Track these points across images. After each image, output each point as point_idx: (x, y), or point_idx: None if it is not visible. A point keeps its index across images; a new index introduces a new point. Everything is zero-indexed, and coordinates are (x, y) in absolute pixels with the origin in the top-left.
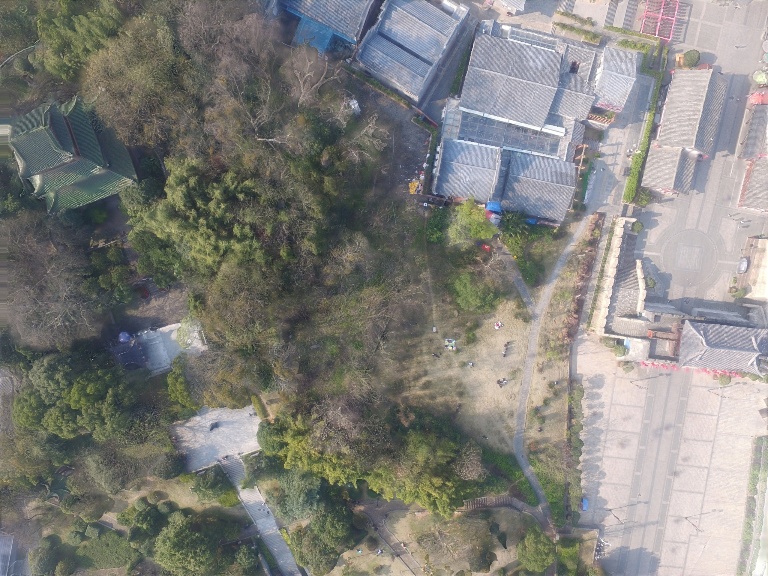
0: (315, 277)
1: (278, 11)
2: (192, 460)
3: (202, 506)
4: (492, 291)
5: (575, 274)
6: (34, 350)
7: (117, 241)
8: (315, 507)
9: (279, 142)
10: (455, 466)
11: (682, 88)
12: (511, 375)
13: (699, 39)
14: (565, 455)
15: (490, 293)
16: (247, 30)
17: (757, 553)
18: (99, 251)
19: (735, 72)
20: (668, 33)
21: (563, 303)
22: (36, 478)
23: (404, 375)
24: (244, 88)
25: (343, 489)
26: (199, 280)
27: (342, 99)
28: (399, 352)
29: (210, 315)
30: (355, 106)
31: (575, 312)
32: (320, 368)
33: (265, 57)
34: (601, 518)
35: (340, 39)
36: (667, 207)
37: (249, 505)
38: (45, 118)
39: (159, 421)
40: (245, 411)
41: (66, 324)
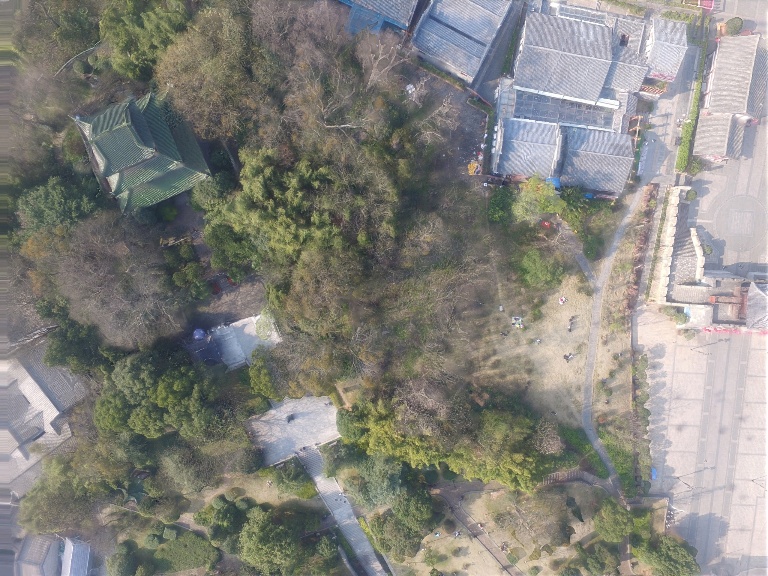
0: (391, 261)
1: None
2: (269, 454)
3: (279, 500)
4: (561, 265)
5: (633, 245)
6: (116, 351)
7: (187, 238)
8: (398, 491)
9: (354, 127)
10: (534, 441)
11: (729, 55)
12: (577, 349)
13: (738, 7)
14: (632, 426)
15: (559, 267)
16: (322, 16)
17: None
18: (169, 249)
19: None
20: (710, 2)
21: (623, 275)
22: (116, 482)
23: (473, 356)
24: (320, 74)
25: (419, 473)
26: (277, 270)
27: (400, 84)
28: None
29: (298, 303)
30: None
31: (634, 283)
32: (392, 354)
33: (338, 43)
34: (669, 486)
35: (390, 26)
36: (717, 174)
37: (326, 496)
38: (126, 115)
39: (235, 417)
40: (320, 401)
41: (146, 323)
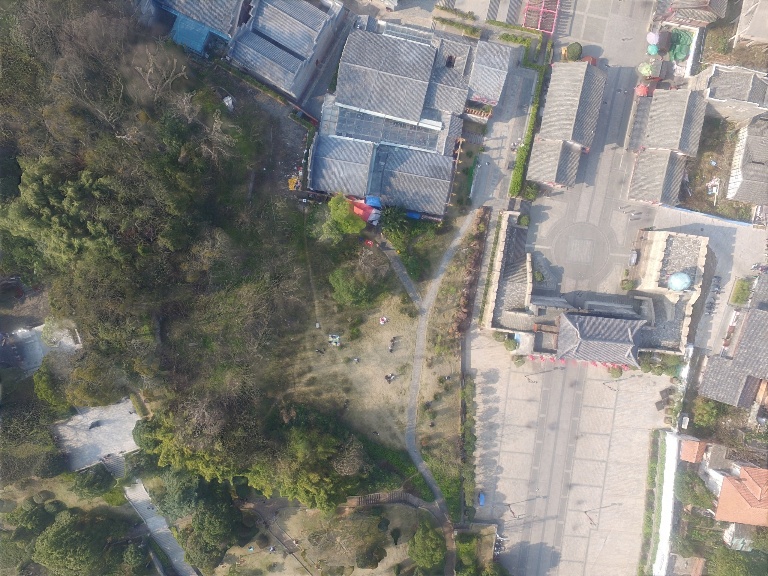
0: (178, 274)
1: (156, 9)
2: (75, 459)
3: (90, 505)
4: (365, 286)
5: (463, 268)
6: None
7: None
8: (193, 505)
9: (128, 139)
10: (333, 462)
11: (561, 81)
12: (400, 370)
13: (585, 32)
14: (460, 450)
15: (363, 288)
16: (84, 27)
17: (656, 546)
18: None
19: (622, 64)
20: (550, 26)
21: (451, 298)
22: None
23: (288, 371)
24: (86, 85)
25: (231, 487)
26: (59, 278)
27: (214, 96)
28: (282, 348)
29: (58, 312)
30: (229, 103)
31: (465, 307)
32: (201, 365)
33: (108, 54)
34: (500, 513)
35: (218, 36)
36: (557, 200)
37: (137, 504)
38: None
39: (38, 420)
40: (126, 409)
41: None
